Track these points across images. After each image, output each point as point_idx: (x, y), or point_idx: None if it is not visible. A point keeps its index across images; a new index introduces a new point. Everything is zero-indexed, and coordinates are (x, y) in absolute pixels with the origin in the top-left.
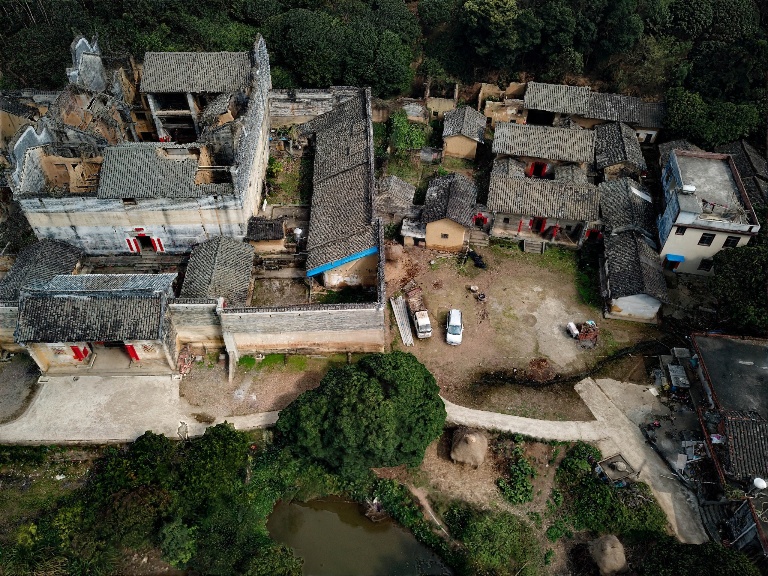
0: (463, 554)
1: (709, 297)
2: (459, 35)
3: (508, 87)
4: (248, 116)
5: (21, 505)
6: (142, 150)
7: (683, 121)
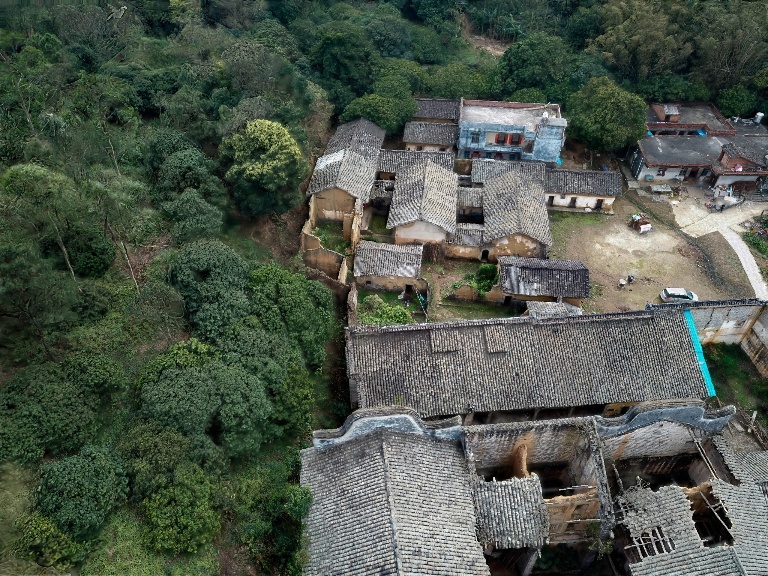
0: None
1: (569, 164)
2: (224, 222)
3: (310, 212)
4: (583, 419)
5: None
6: (747, 571)
7: (397, 113)
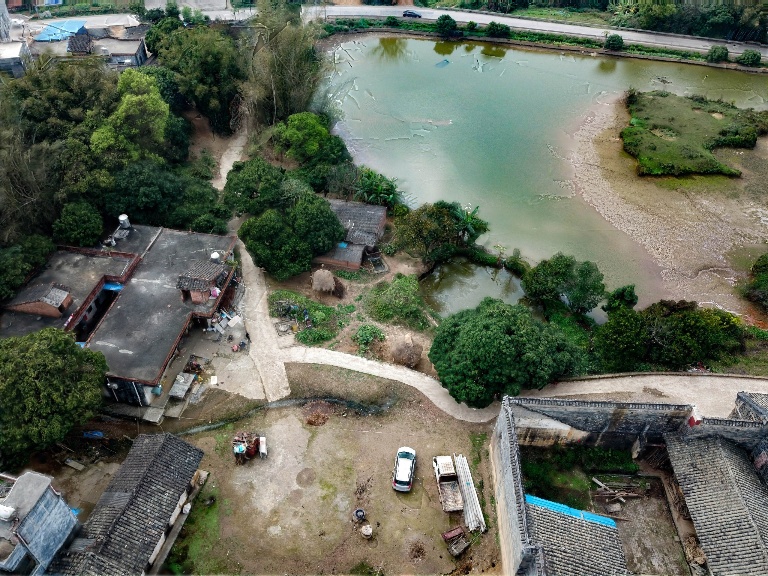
0: (418, 305)
1: None
2: None
3: None
4: None
5: (765, 359)
6: None
7: None
